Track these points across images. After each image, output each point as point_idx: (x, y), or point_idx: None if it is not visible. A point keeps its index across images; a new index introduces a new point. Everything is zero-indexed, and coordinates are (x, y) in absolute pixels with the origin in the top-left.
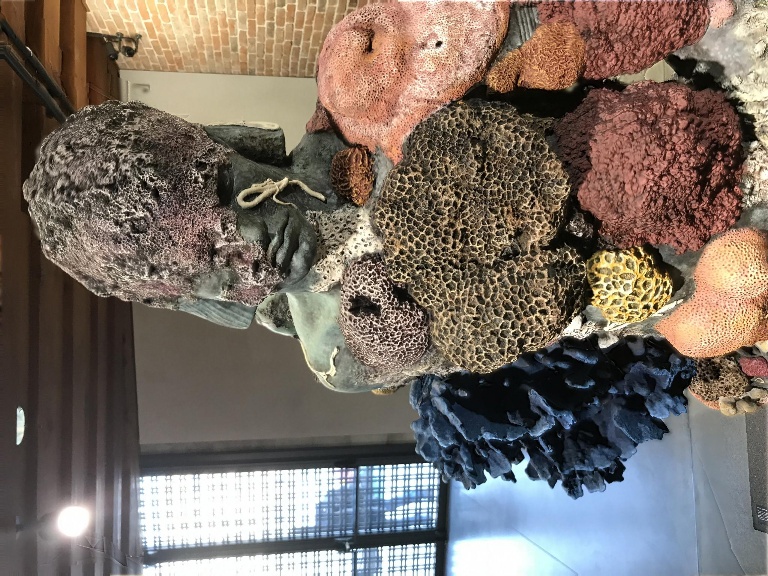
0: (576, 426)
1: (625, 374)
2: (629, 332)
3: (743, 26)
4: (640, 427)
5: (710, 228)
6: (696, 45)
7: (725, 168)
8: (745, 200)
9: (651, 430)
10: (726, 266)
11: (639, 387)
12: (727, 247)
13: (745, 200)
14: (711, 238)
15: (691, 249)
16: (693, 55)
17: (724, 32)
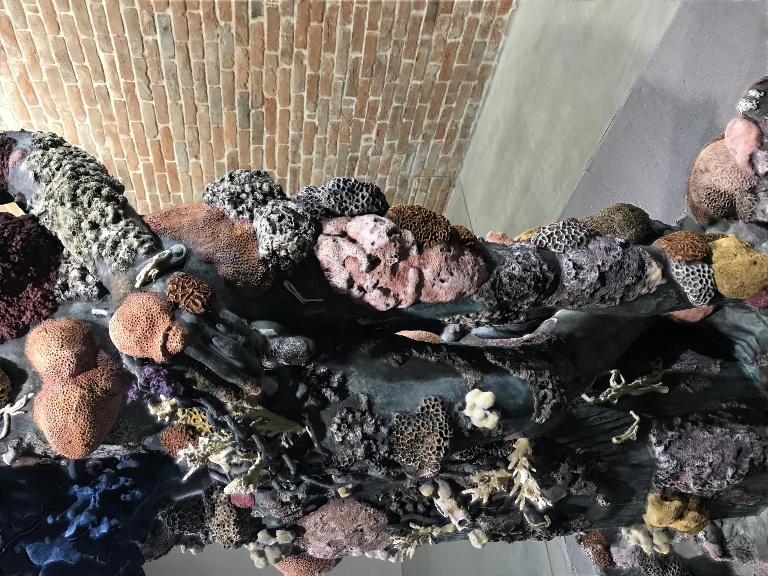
0: (27, 570)
1: (72, 503)
2: (36, 446)
3: (24, 164)
4: (53, 550)
5: (22, 318)
6: (9, 184)
7: (11, 263)
8: (58, 294)
9: (60, 551)
10: (39, 350)
11: (69, 510)
12: (39, 333)
13: (58, 294)
14: (30, 328)
15: (8, 338)
16: (13, 192)
17: (16, 170)
